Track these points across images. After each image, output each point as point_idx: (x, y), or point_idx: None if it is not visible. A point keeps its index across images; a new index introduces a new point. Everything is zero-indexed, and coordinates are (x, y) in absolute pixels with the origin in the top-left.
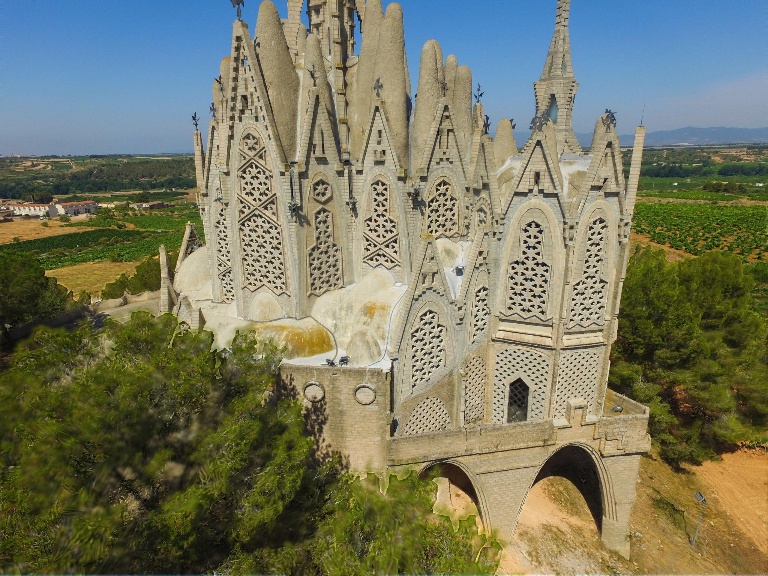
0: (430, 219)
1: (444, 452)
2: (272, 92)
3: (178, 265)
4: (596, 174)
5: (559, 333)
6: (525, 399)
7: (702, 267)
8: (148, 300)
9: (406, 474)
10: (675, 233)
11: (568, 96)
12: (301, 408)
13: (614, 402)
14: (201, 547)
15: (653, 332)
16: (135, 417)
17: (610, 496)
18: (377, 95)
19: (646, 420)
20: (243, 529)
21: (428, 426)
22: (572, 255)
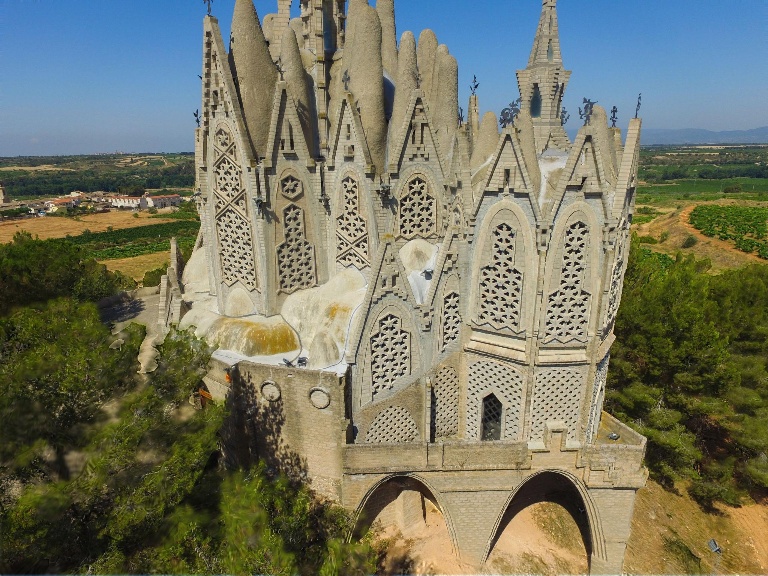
0: (403, 218)
1: (404, 465)
2: (244, 87)
3: None
4: (574, 172)
5: (532, 348)
6: (500, 416)
7: (743, 281)
8: None
9: (363, 484)
10: (766, 241)
11: (552, 85)
12: (259, 406)
13: (611, 428)
14: (86, 539)
15: (672, 352)
16: (6, 406)
17: (598, 532)
18: (345, 88)
19: (640, 452)
20: (114, 527)
21: (393, 436)
22: (544, 262)
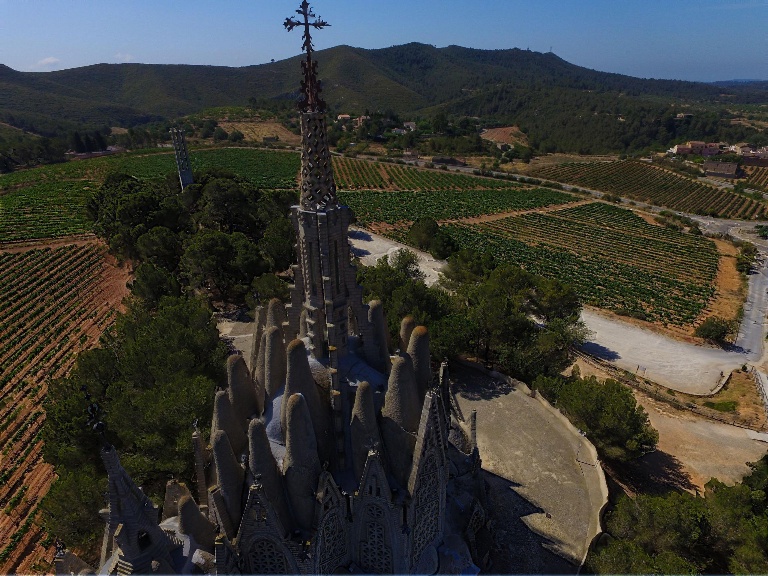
0: None
1: None
2: None
3: None
4: None
5: None
6: None
7: None
8: (545, 408)
9: None
10: None
11: None
12: None
13: None
14: None
15: None
16: None
17: None
18: None
19: None
20: None
21: None
22: None
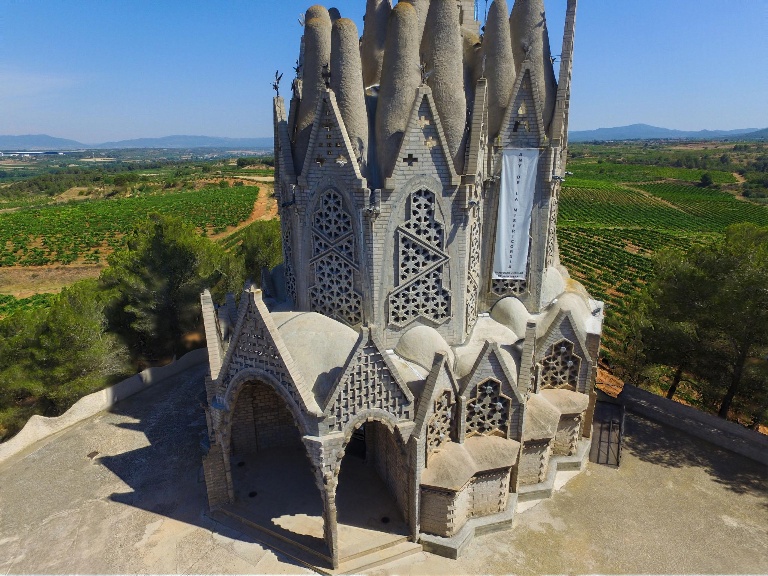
0: None
1: None
2: None
3: (300, 382)
4: None
5: None
6: None
7: None
8: None
9: None
10: None
11: None
12: None
13: None
14: None
15: None
16: None
17: None
18: None
19: None
20: None
21: None
22: None
